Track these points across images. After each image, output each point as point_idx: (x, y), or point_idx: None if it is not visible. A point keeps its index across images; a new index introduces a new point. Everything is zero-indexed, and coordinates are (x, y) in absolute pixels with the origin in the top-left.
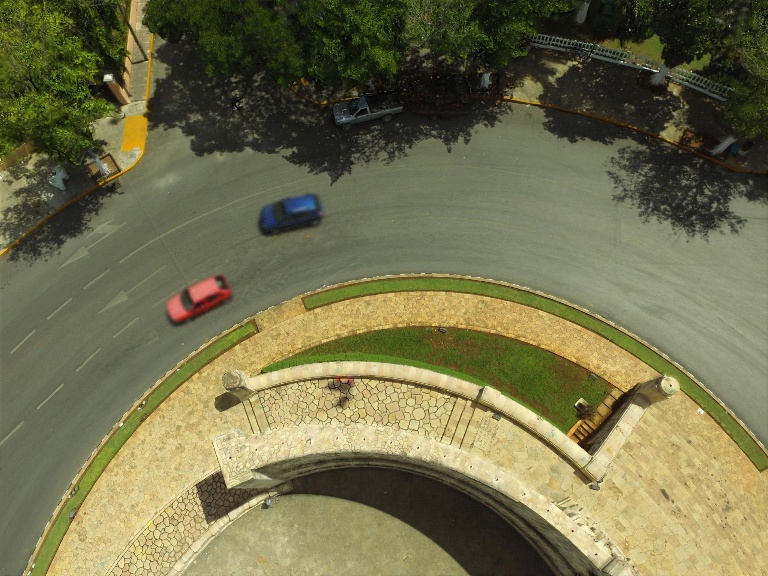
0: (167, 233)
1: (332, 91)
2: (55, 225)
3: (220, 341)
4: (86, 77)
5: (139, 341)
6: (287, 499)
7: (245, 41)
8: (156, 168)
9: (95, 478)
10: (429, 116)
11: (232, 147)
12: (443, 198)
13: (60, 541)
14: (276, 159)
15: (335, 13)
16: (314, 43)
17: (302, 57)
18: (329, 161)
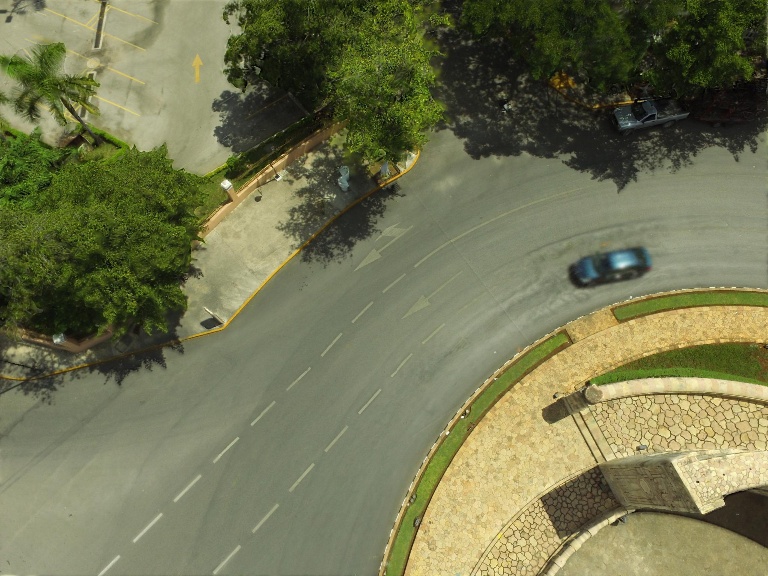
0: (457, 238)
1: (603, 95)
2: (342, 226)
3: (534, 351)
4: (429, 79)
5: (450, 348)
6: (636, 517)
7: (586, 45)
8: (434, 171)
9: (432, 487)
10: (712, 123)
11: (508, 151)
12: (739, 209)
13: (409, 549)
14: (556, 164)
15: (696, 17)
16: (646, 47)
17: (632, 62)
18: (612, 167)
